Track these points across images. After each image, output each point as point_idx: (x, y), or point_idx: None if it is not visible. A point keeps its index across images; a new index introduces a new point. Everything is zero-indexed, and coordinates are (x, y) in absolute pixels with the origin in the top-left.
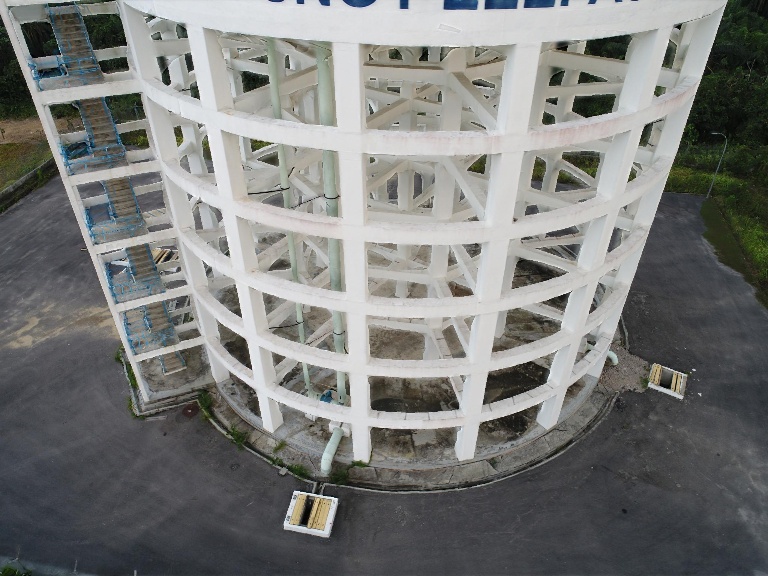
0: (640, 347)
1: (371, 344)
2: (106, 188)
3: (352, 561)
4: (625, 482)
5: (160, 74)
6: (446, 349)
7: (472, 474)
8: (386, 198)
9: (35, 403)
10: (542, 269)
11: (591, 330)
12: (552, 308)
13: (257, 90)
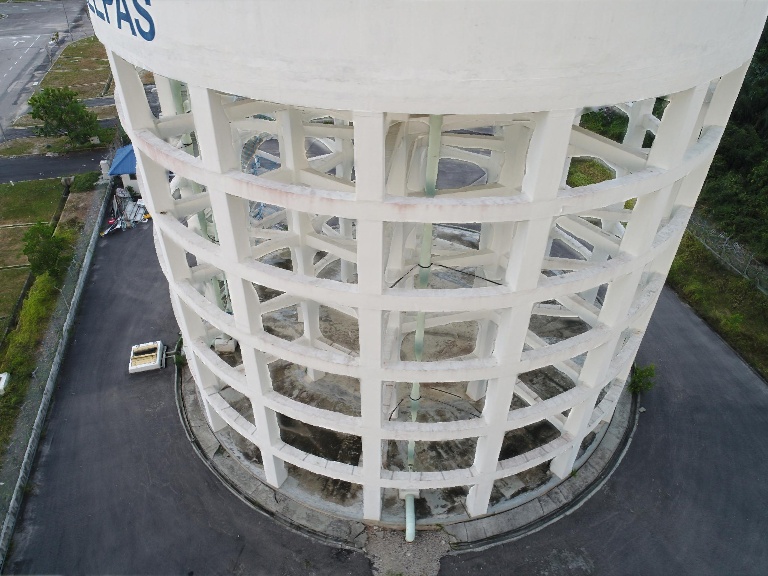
0: (460, 568)
1: (325, 330)
2: (237, 99)
3: (114, 392)
4: (228, 571)
5: None
6: None
7: (204, 439)
8: None
9: (210, 216)
10: (540, 431)
11: (278, 411)
12: None
13: None
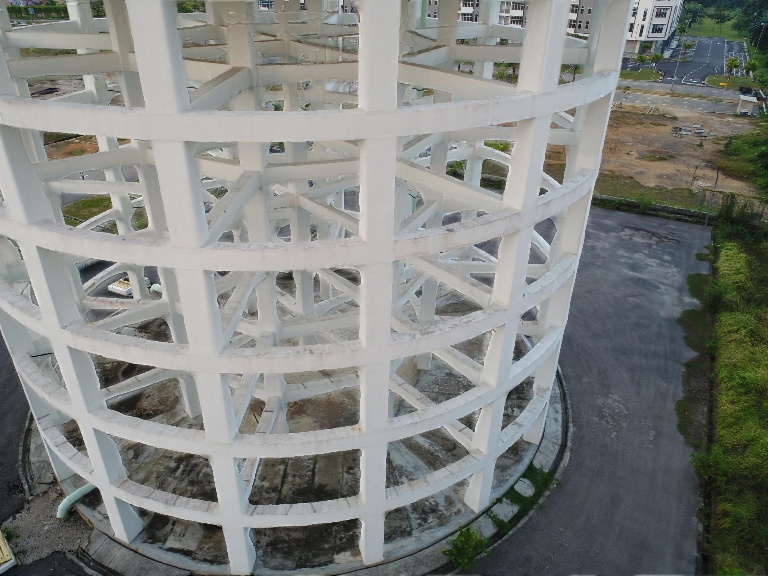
0: (54, 572)
1: None
2: None
3: None
4: None
5: (245, 12)
6: (146, 302)
7: None
8: (422, 308)
9: None
10: None
11: None
12: (123, 384)
13: (184, 17)
